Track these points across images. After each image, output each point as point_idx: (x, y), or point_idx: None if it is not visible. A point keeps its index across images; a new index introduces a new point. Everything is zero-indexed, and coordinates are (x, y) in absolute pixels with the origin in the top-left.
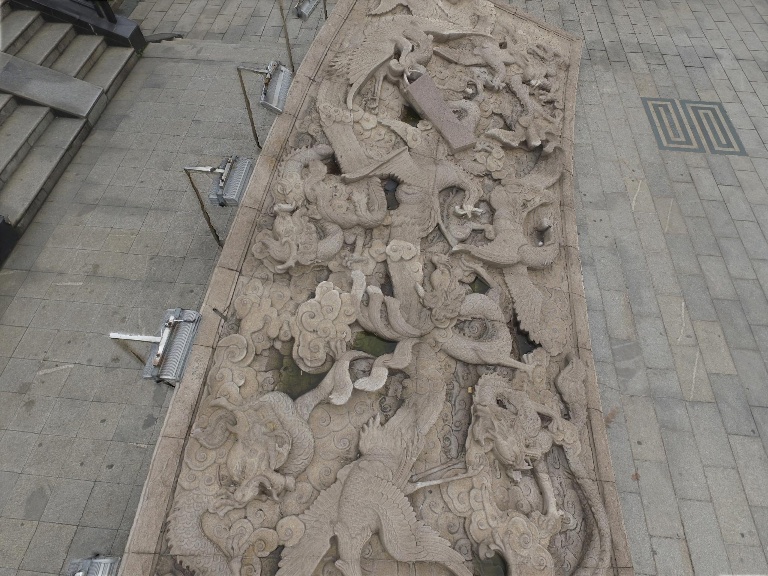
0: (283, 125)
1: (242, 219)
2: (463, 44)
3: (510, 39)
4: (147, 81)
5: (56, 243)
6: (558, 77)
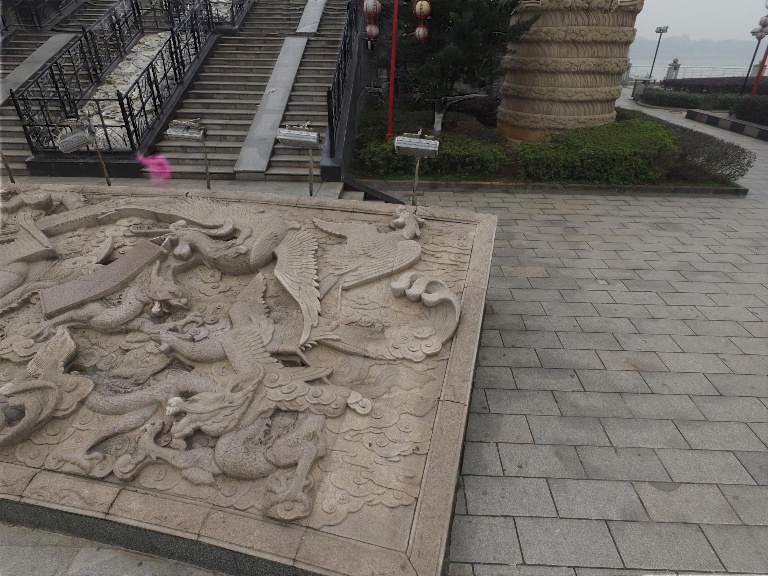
0: (120, 189)
1: (19, 185)
2: (286, 309)
3: (321, 375)
4: (288, 186)
5: (125, 184)
6: (236, 488)
